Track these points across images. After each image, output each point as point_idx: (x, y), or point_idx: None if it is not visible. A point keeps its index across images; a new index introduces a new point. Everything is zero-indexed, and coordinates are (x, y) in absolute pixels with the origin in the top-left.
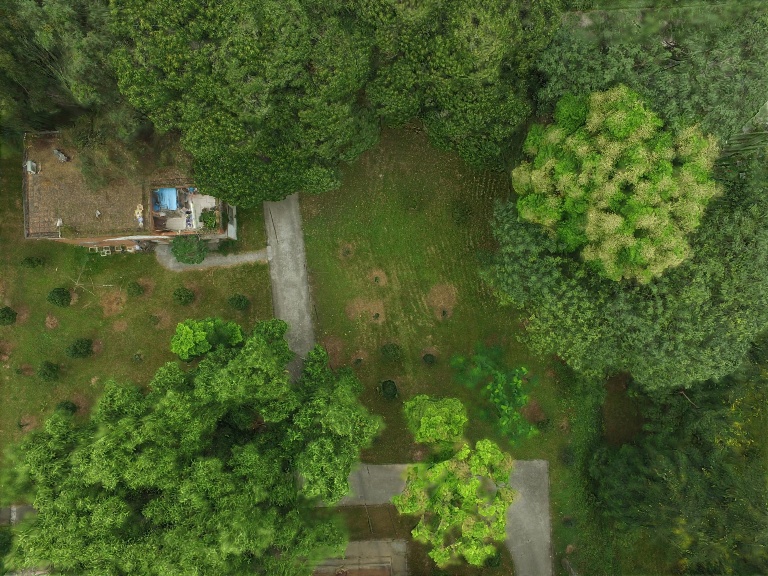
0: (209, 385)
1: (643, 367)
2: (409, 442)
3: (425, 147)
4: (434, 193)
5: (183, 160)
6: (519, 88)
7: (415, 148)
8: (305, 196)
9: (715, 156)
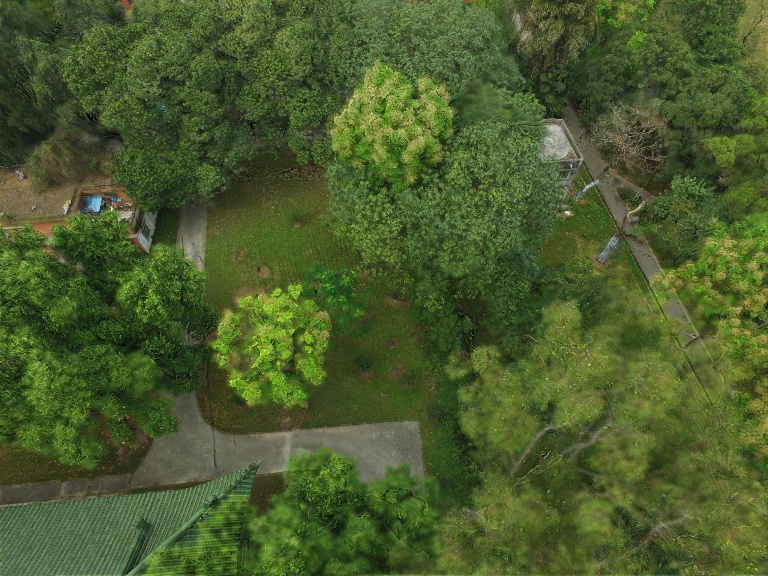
0: (64, 228)
1: (443, 251)
2: (278, 408)
3: (308, 189)
4: (314, 215)
5: (109, 165)
6: (336, 95)
7: (300, 190)
8: (212, 224)
9: (448, 97)
